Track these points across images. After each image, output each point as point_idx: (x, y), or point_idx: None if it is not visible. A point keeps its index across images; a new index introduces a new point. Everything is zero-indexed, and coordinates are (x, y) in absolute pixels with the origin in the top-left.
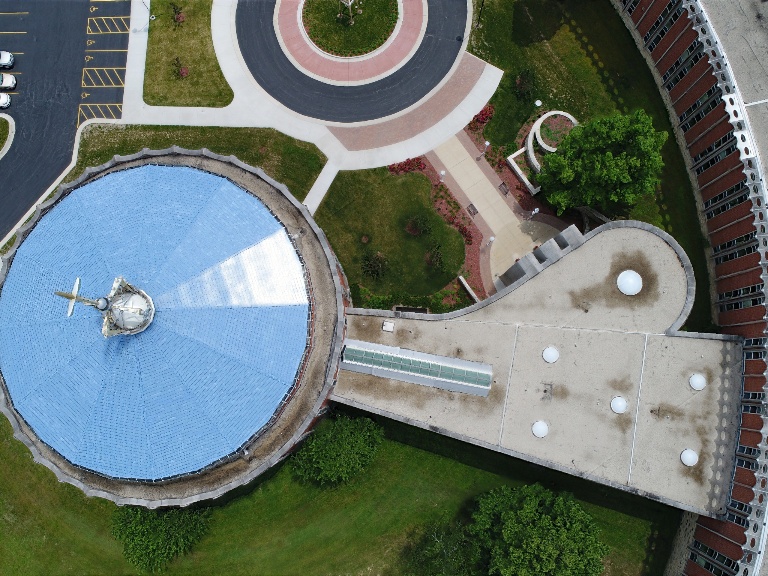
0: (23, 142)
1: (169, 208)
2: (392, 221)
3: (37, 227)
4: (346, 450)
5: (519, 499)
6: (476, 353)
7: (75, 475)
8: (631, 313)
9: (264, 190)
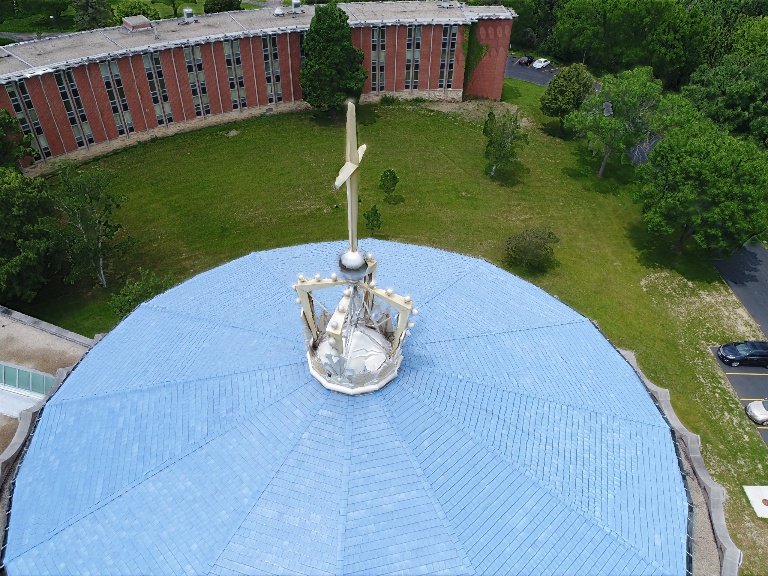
0: None
1: None
2: None
3: None
4: None
5: None
6: None
7: None
8: None
9: None
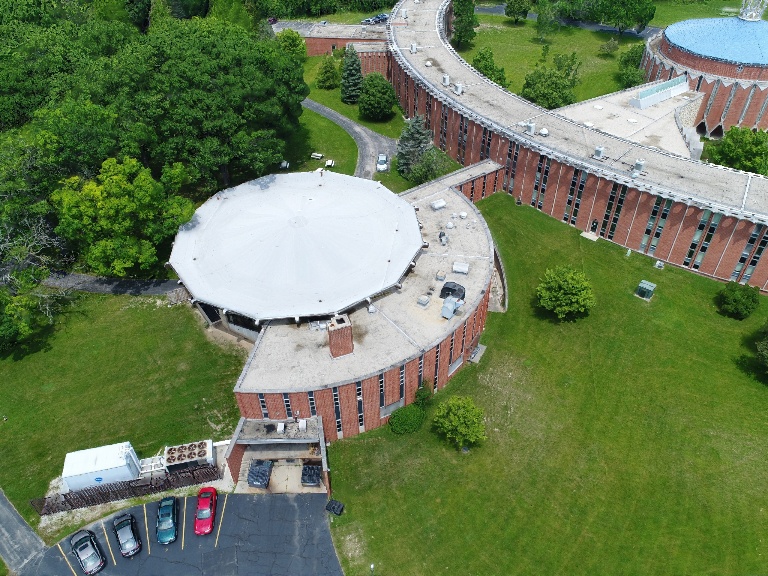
0: None
1: None
2: None
3: None
4: None
5: None
6: (652, 109)
7: None
8: None
9: None
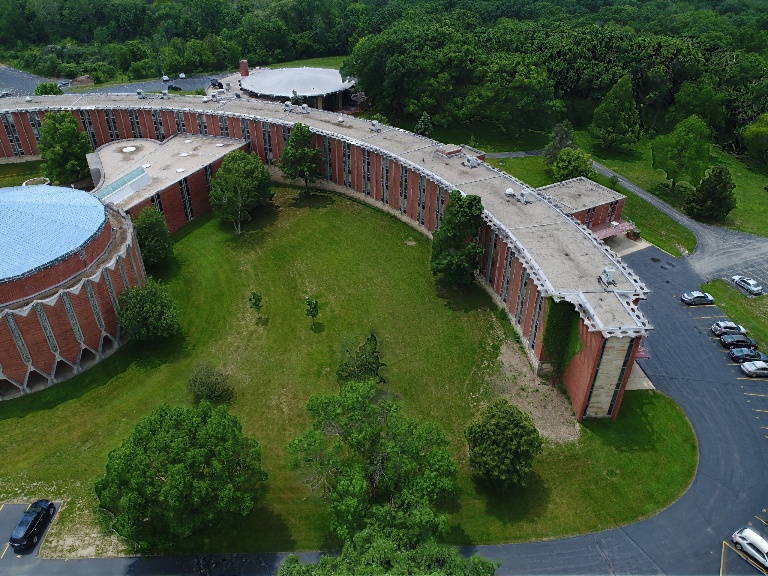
0: None
1: None
2: None
3: None
4: None
5: None
6: None
7: None
8: None
9: None
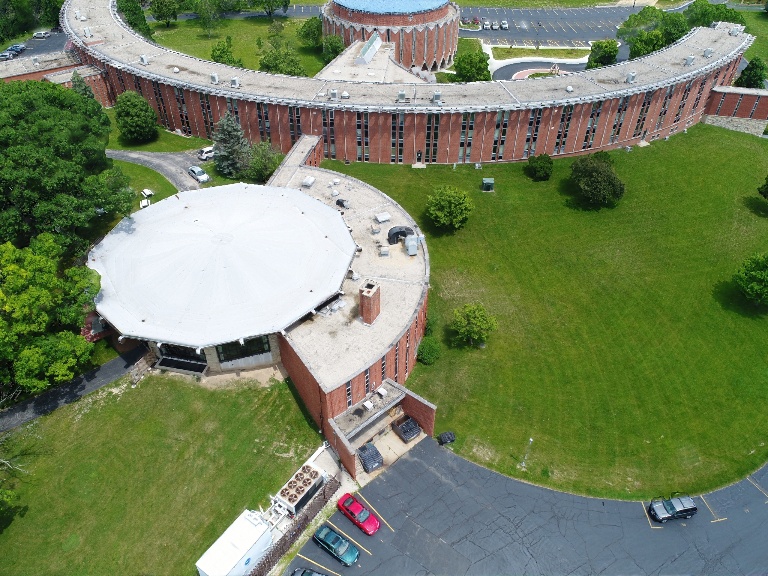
0: None
1: None
2: None
3: None
4: None
5: None
6: None
7: None
8: None
9: None
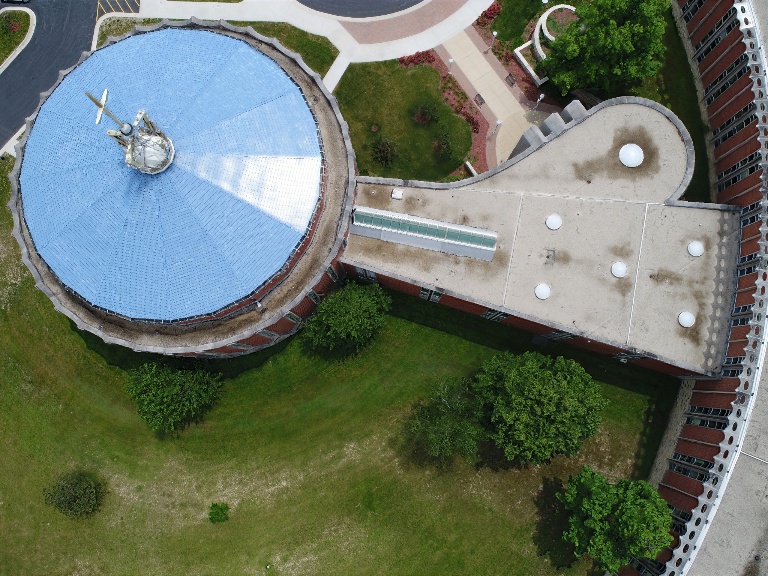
0: (43, 34)
1: (188, 65)
2: (401, 111)
3: (61, 85)
4: (355, 307)
5: (521, 363)
6: (482, 220)
7: (94, 325)
8: (632, 184)
9: (279, 60)
